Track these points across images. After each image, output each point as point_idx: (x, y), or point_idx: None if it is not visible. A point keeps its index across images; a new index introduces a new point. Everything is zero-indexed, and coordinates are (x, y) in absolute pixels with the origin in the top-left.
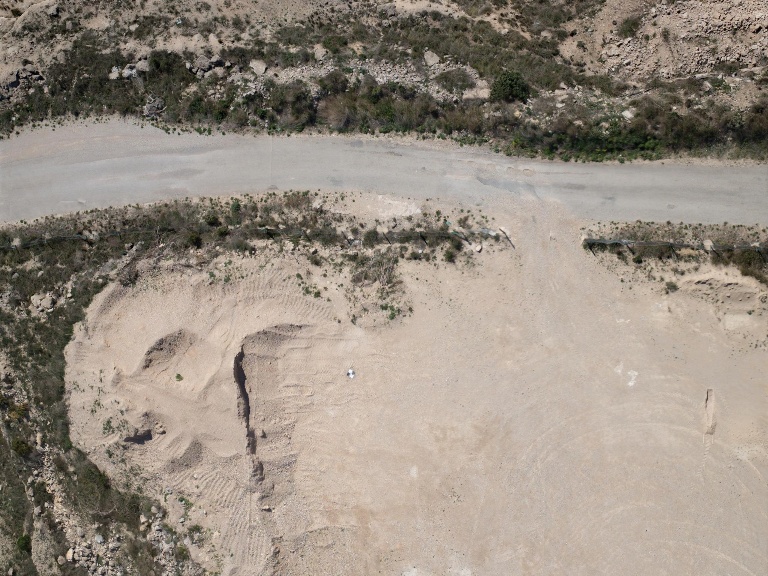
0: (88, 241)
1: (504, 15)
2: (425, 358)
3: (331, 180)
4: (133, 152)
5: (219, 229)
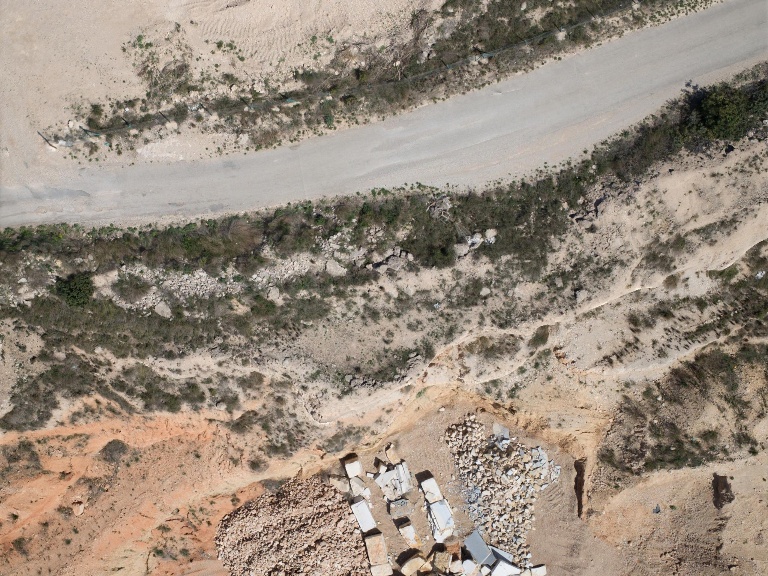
0: (478, 51)
1: (109, 371)
2: (100, 5)
3: (236, 166)
4: (452, 156)
5: (338, 92)
